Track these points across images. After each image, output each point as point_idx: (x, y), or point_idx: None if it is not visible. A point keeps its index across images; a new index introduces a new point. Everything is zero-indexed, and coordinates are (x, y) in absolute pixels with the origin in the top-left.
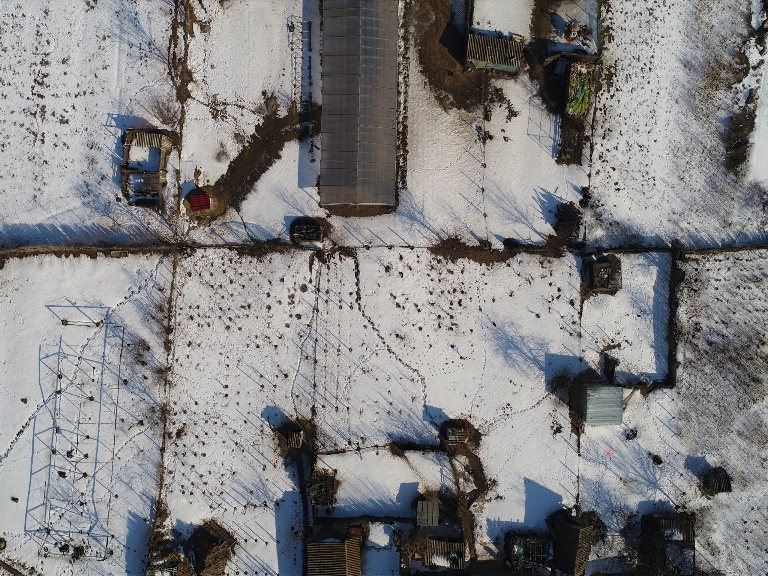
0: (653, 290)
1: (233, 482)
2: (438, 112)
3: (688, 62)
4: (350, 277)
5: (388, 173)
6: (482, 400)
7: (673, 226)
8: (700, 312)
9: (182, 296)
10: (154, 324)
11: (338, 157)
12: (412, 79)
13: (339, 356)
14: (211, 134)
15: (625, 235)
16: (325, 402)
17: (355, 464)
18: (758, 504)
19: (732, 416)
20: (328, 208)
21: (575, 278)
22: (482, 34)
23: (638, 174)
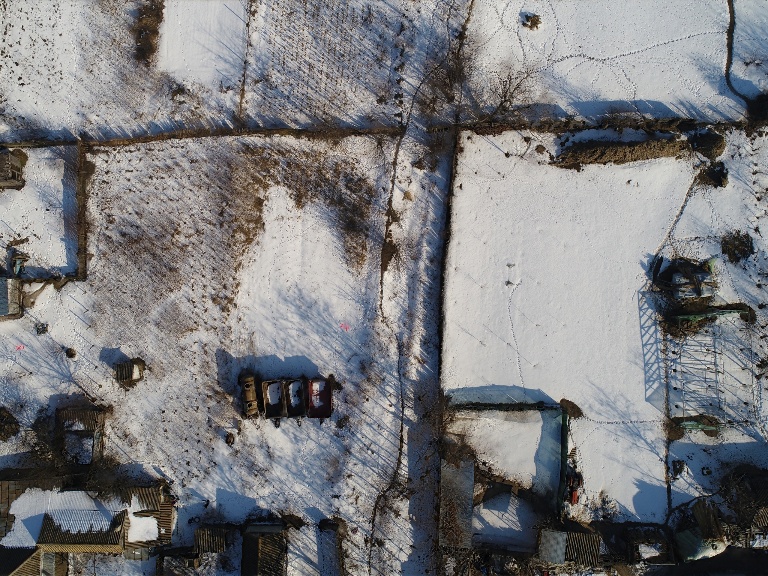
0: (62, 183)
1: None
2: None
3: None
4: None
5: None
6: None
7: (81, 119)
8: (113, 204)
9: None
10: None
11: None
12: None
13: None
14: None
15: (31, 129)
16: None
17: None
18: (178, 393)
19: (149, 306)
20: None
21: None
22: None
23: (44, 68)
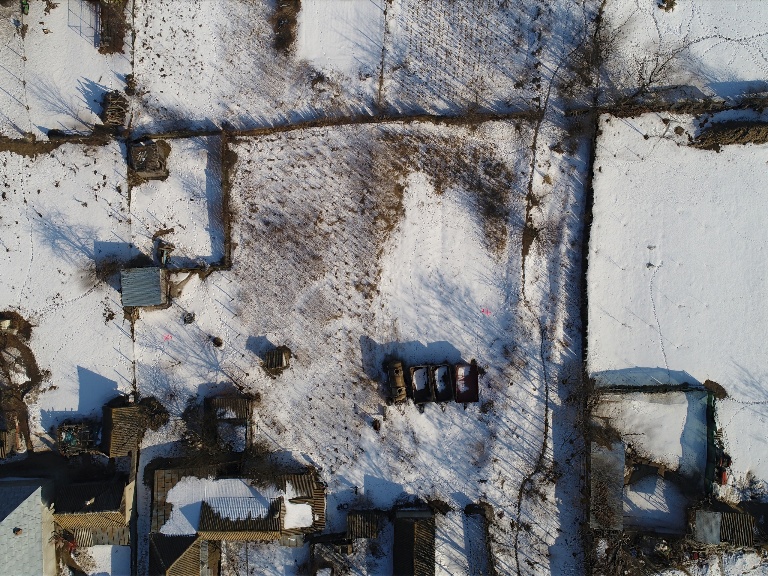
0: (205, 173)
1: None
2: None
3: None
4: None
5: None
6: (31, 291)
7: (223, 109)
8: (255, 193)
9: None
10: None
11: None
12: None
13: None
14: None
15: (174, 120)
16: None
17: None
18: (324, 381)
19: (293, 294)
20: None
21: (121, 165)
22: None
23: (185, 59)
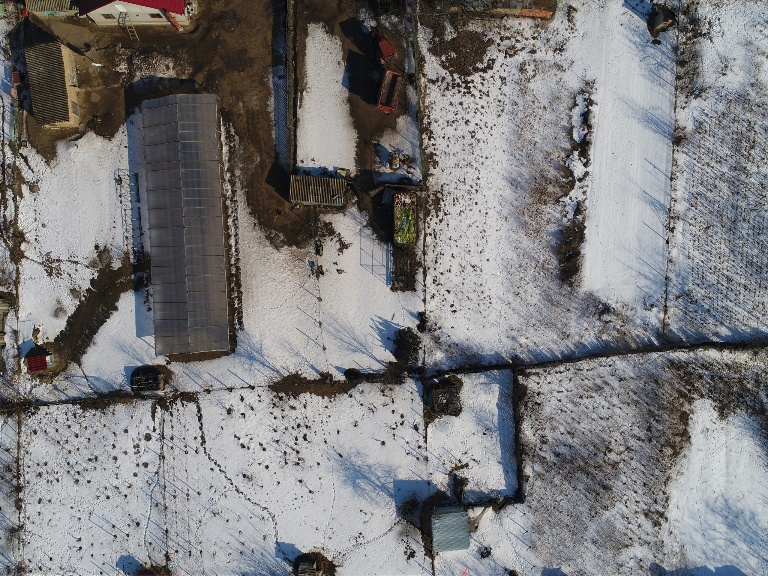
0: (497, 407)
1: None
2: (269, 251)
3: (514, 180)
4: (193, 422)
5: (220, 319)
6: (334, 532)
7: (512, 342)
8: (545, 425)
9: (29, 454)
10: (3, 484)
11: (169, 308)
12: (241, 221)
13: (188, 501)
14: (47, 292)
15: (465, 355)
16: (178, 547)
17: None
18: None
19: (585, 525)
20: (168, 355)
21: (417, 403)
22: (307, 171)
23: (473, 294)
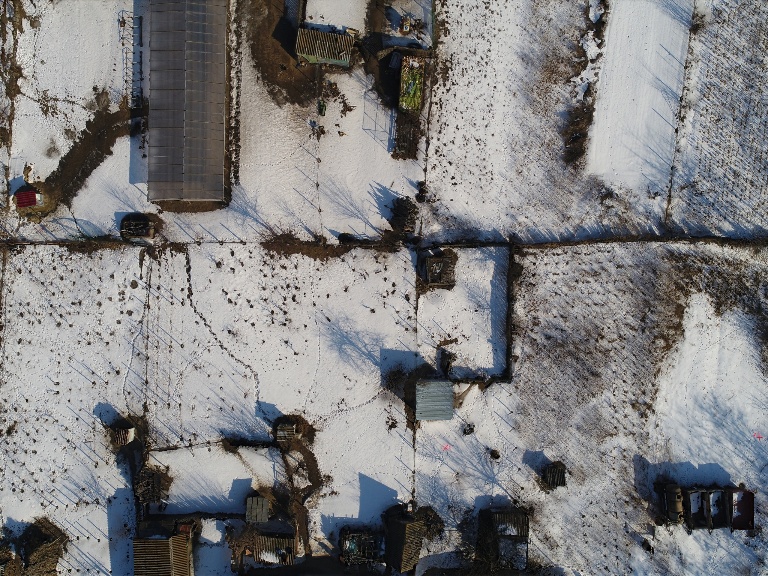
0: (491, 284)
1: (65, 479)
2: (271, 107)
3: (526, 56)
4: (181, 273)
5: (216, 168)
6: (316, 396)
7: (511, 220)
8: (538, 306)
9: (12, 293)
10: None
11: (165, 152)
12: (244, 74)
13: (171, 352)
14: (41, 130)
15: (462, 229)
16: (157, 399)
17: (187, 461)
18: (597, 498)
19: (571, 410)
20: (160, 204)
21: (410, 273)
22: (315, 28)
23: (475, 168)
